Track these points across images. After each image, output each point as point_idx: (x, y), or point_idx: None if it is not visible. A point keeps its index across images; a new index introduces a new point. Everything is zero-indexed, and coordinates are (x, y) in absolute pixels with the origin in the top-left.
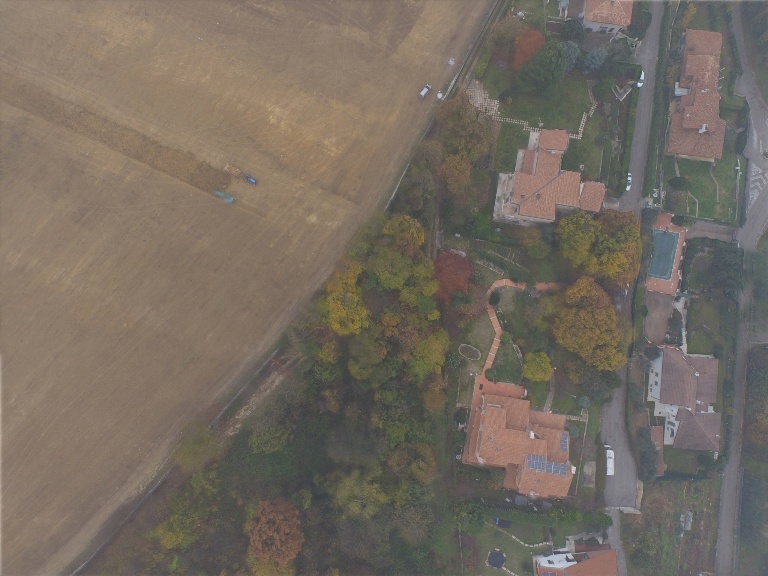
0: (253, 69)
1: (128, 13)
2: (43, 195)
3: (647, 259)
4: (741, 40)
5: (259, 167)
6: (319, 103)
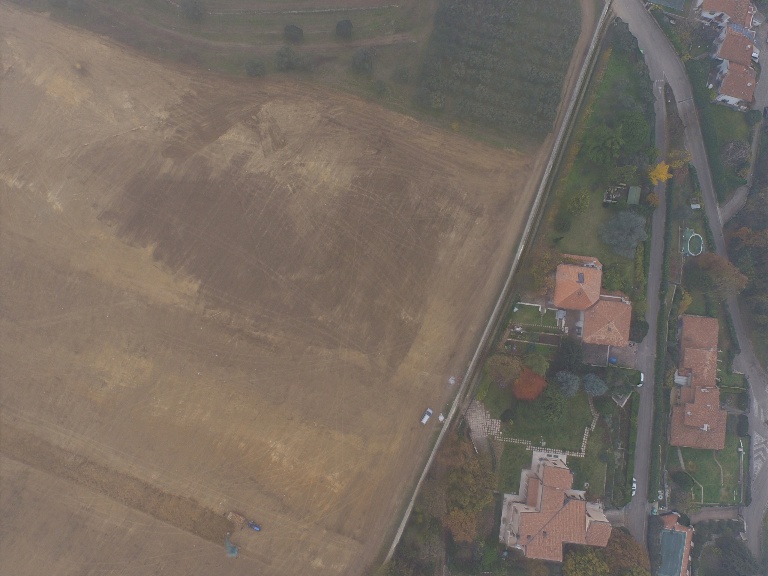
0: (253, 403)
1: (127, 350)
2: (45, 554)
3: (656, 572)
4: (737, 311)
5: (262, 510)
6: (321, 435)
